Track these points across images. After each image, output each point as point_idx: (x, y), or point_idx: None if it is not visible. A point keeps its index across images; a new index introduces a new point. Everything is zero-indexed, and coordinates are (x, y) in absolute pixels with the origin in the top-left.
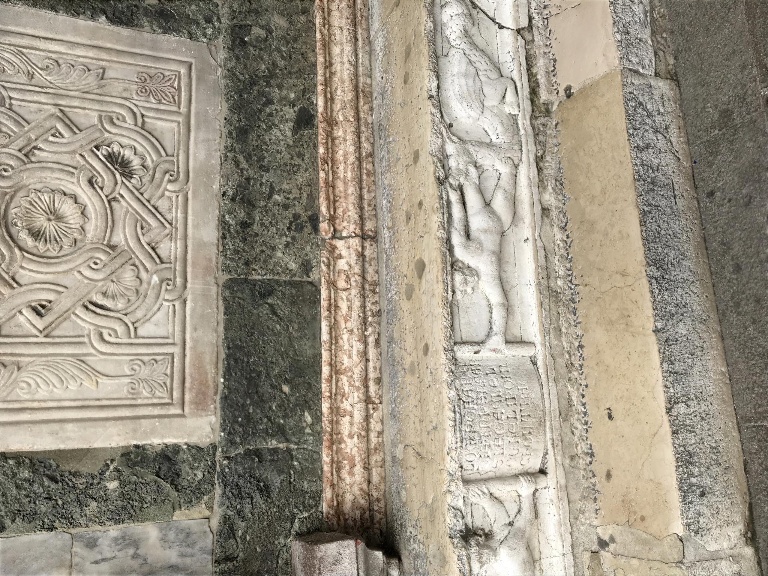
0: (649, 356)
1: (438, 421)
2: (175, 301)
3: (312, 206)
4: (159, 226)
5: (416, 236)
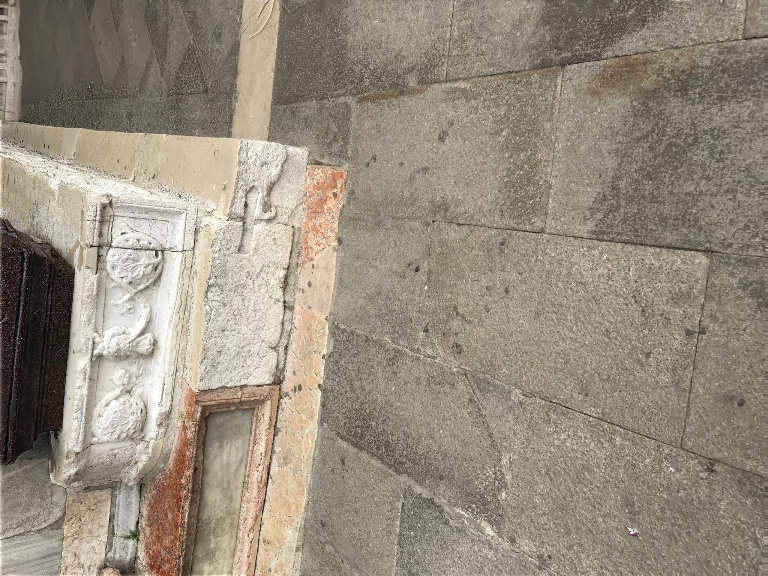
0: (116, 135)
1: (21, 174)
2: None
3: None
4: None
5: (5, 180)
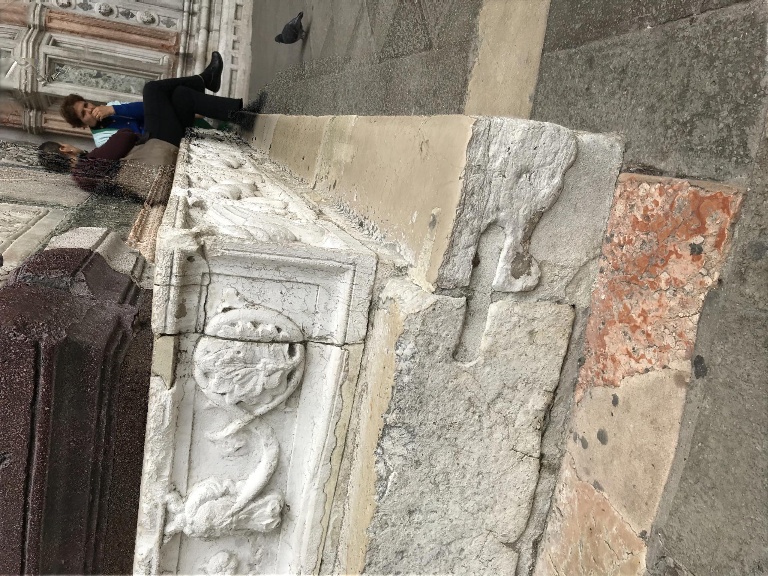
0: None
1: None
2: (4, 240)
3: (124, 237)
4: (4, 228)
5: None
